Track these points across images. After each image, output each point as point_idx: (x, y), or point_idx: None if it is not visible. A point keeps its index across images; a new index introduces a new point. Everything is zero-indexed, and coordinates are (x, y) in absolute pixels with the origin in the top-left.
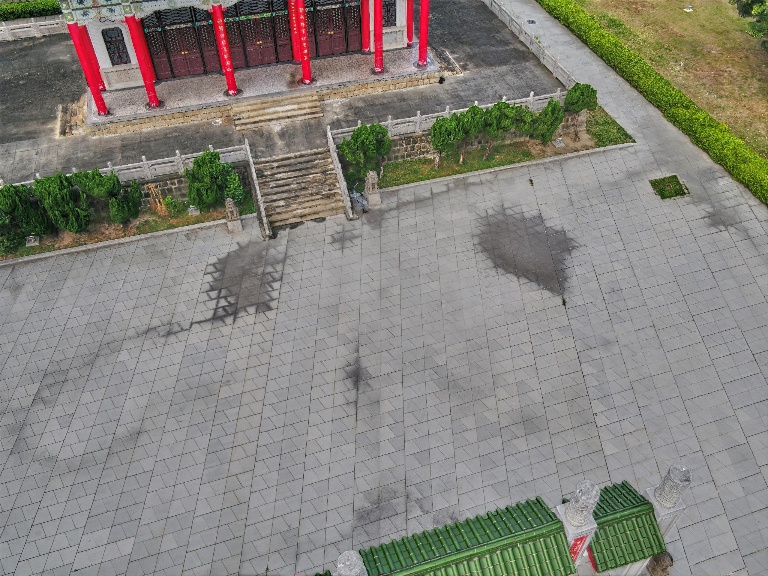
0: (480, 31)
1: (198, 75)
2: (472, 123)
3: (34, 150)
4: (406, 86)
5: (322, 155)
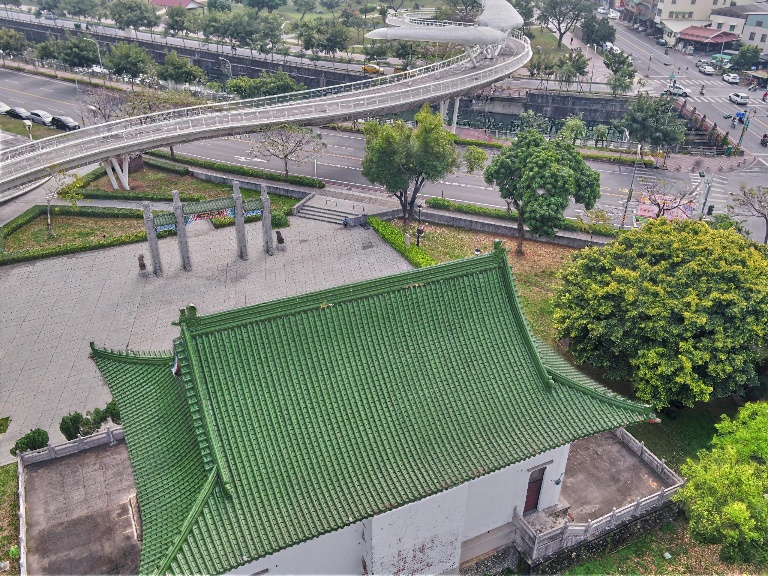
0: None
1: None
2: None
3: None
4: None
5: None
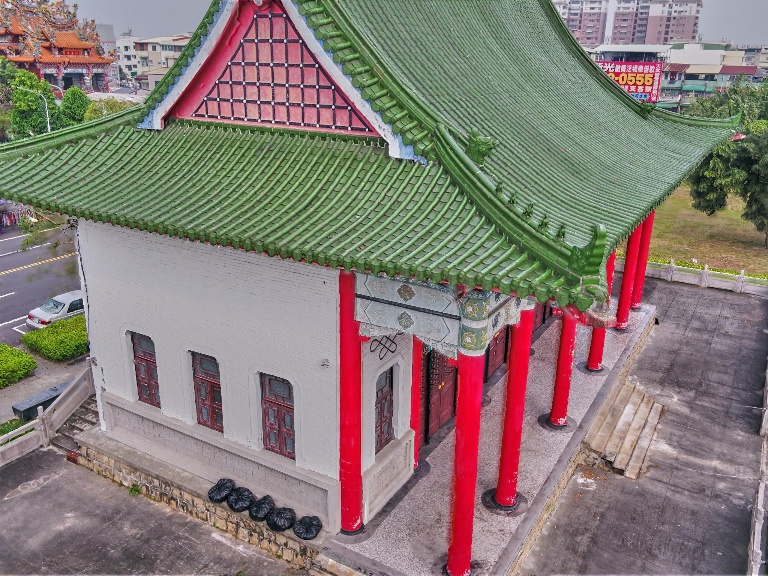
0: None
1: (451, 422)
2: None
3: None
4: None
5: None
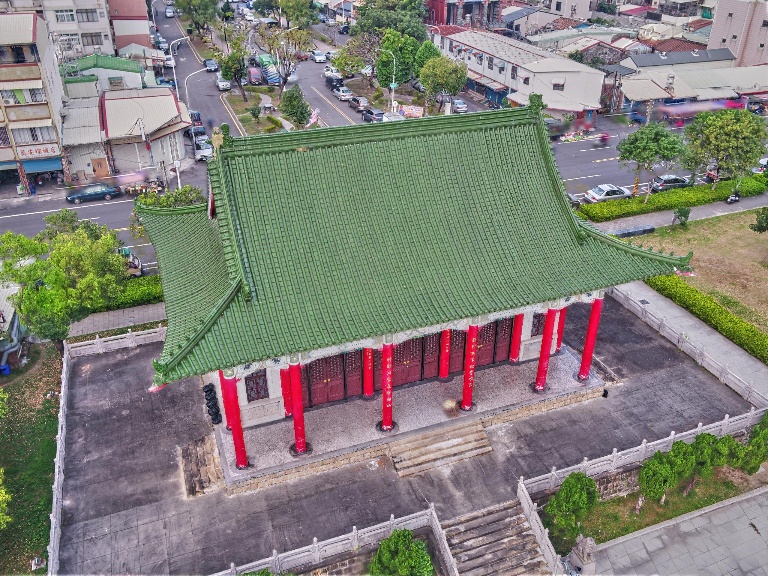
0: (613, 324)
1: (338, 402)
2: (685, 465)
3: (161, 521)
4: (569, 403)
5: (512, 510)
